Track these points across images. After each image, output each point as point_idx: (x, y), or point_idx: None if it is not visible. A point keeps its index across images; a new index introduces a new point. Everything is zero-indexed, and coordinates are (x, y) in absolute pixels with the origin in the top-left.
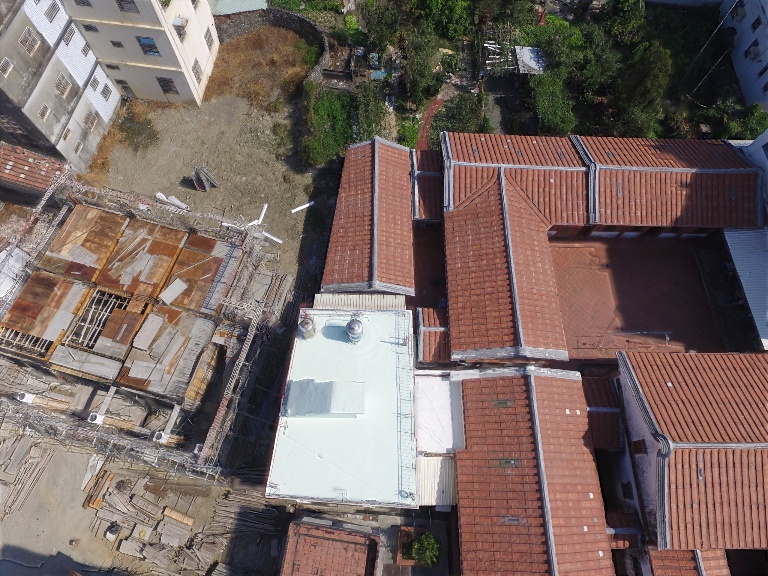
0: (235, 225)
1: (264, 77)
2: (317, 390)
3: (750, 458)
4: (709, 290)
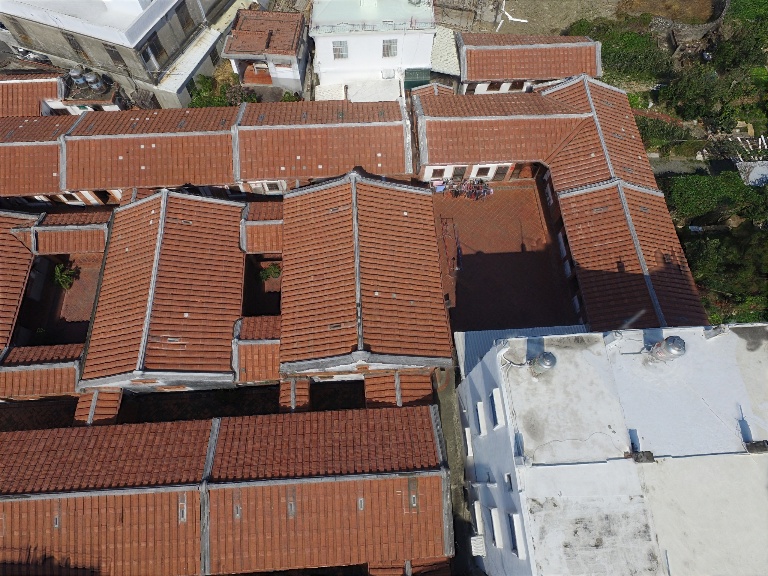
0: None
1: (651, 6)
2: None
3: (347, 244)
4: None
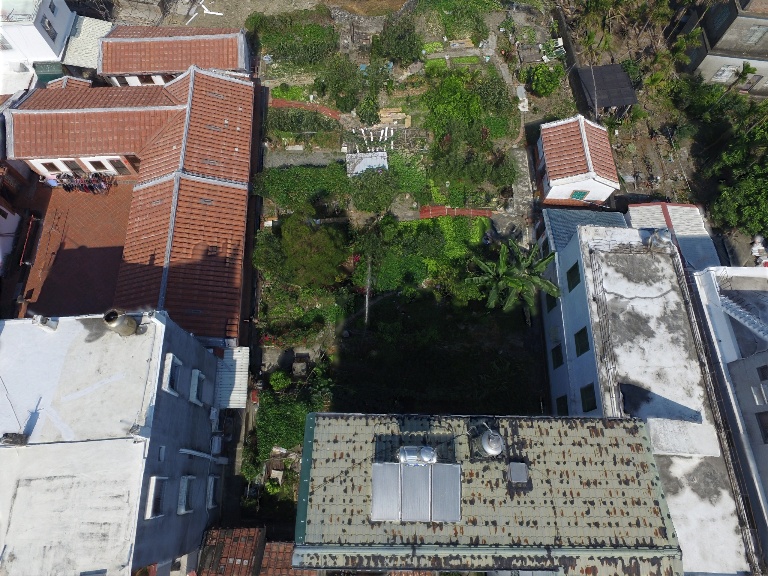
0: None
1: None
2: None
3: None
4: None
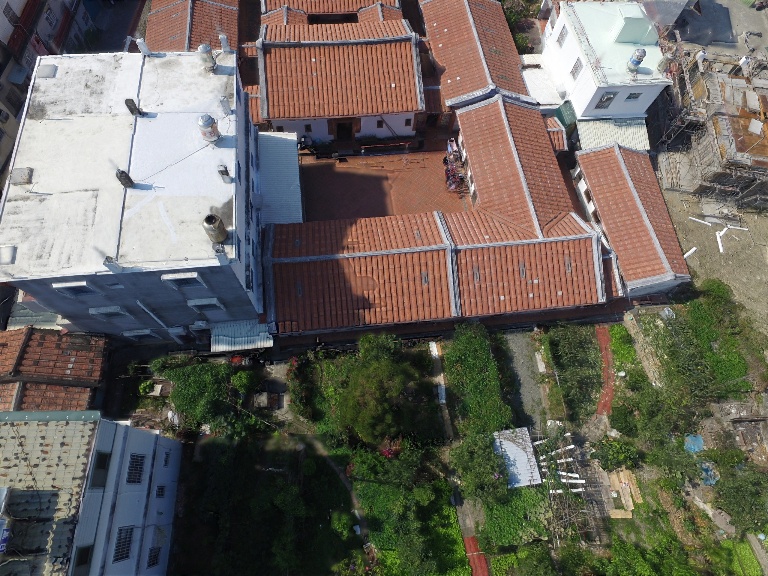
0: (750, 156)
1: None
2: None
3: None
4: (303, 211)
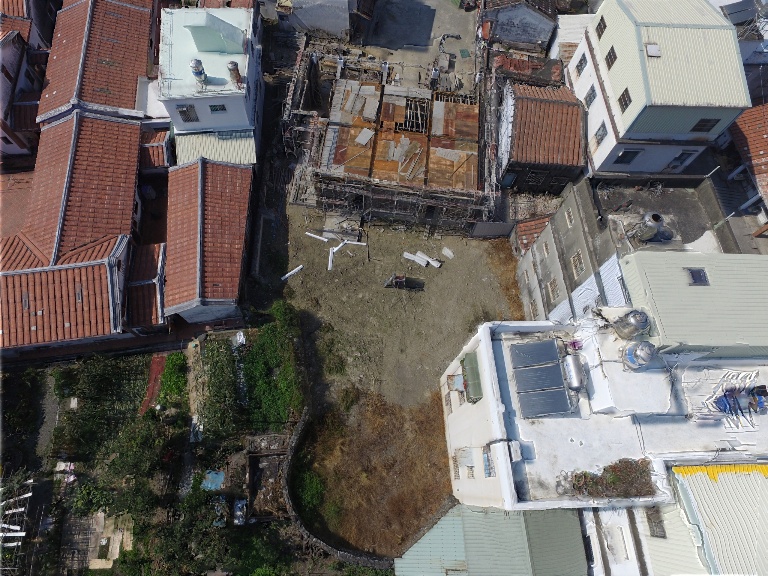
0: None
1: (374, 444)
2: (219, 28)
3: None
4: None
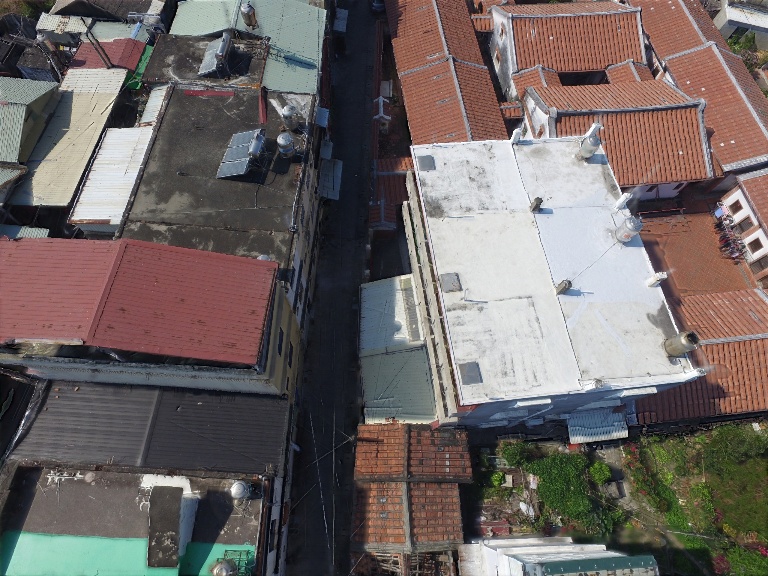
0: None
1: None
2: None
3: None
4: None
